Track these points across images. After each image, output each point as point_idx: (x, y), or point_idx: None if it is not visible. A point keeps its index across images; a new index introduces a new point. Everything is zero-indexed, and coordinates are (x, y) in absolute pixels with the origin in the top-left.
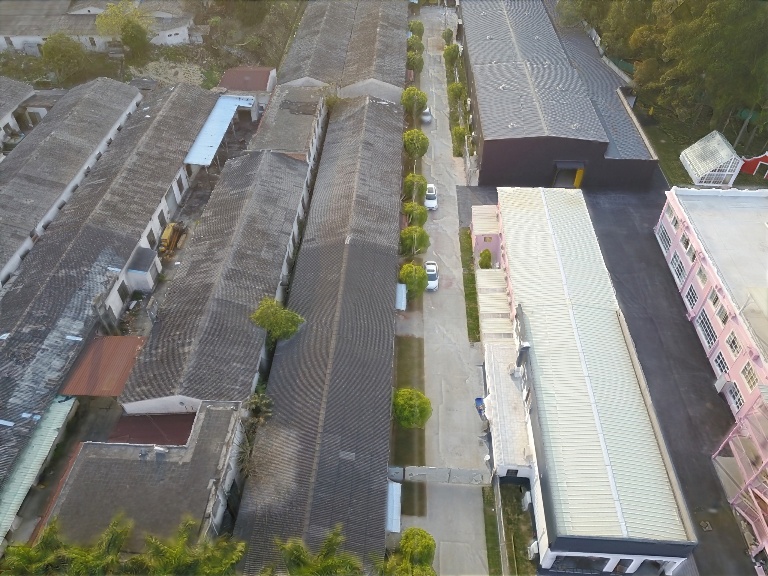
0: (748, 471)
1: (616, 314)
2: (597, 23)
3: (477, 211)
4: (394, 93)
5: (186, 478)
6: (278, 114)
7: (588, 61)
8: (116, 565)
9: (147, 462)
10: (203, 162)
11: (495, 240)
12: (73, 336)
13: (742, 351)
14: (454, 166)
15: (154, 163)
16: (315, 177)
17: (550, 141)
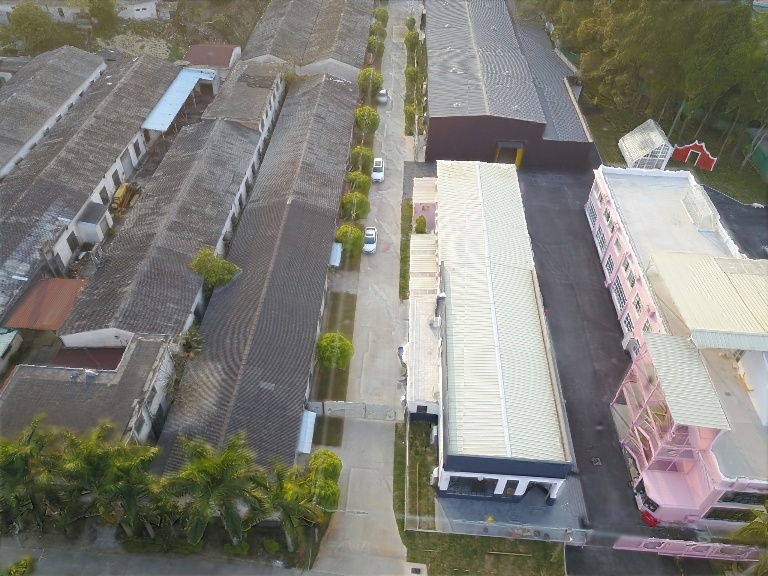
0: (635, 412)
1: (531, 273)
2: (552, 17)
3: (418, 182)
4: (352, 74)
5: (112, 397)
6: (236, 86)
7: (540, 52)
8: (36, 459)
9: (77, 383)
10: (160, 128)
11: (433, 209)
12: (19, 276)
13: (643, 310)
14: (404, 143)
15: (111, 126)
16: (267, 146)
17: (491, 120)
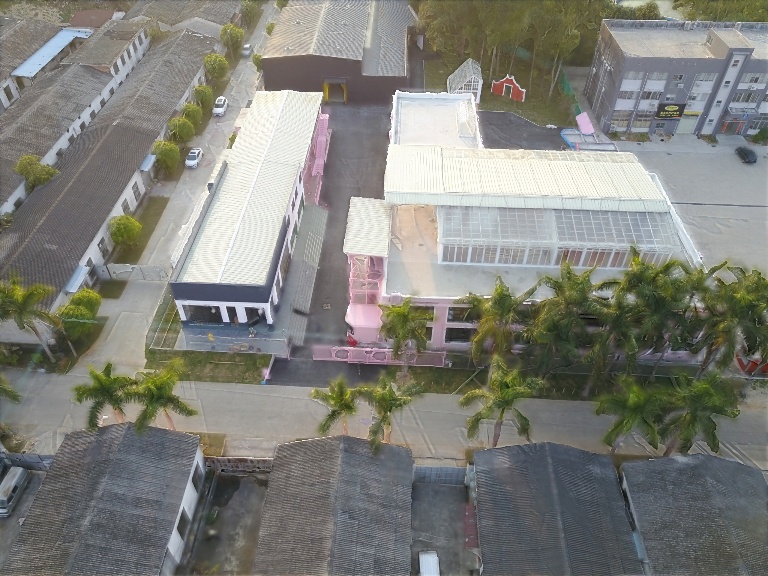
0: None
1: None
2: None
3: (244, 112)
4: (218, 31)
5: None
6: (99, 39)
7: (395, 8)
8: None
9: None
10: (28, 74)
11: None
12: None
13: None
14: (254, 87)
15: None
16: None
17: (313, 59)
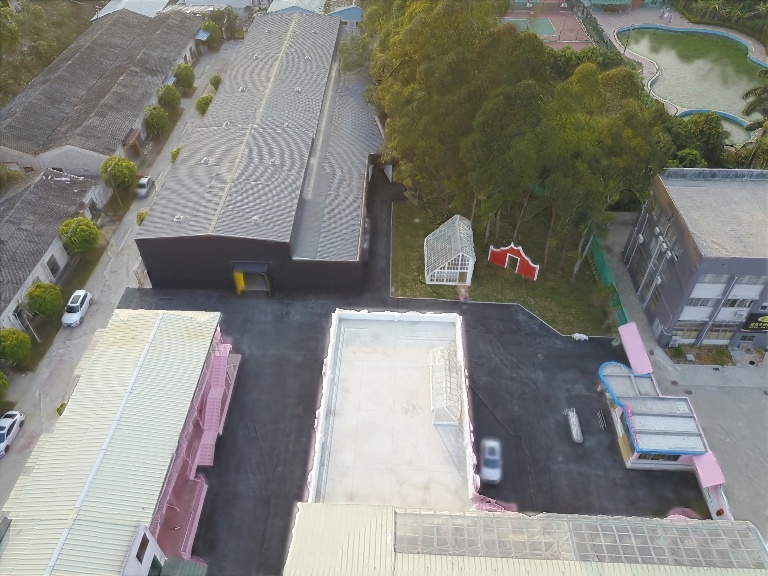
0: None
1: None
2: None
3: (98, 337)
4: (101, 161)
5: None
6: None
7: (355, 117)
8: None
9: None
10: None
11: None
12: None
13: None
14: None
15: None
16: None
17: (215, 240)
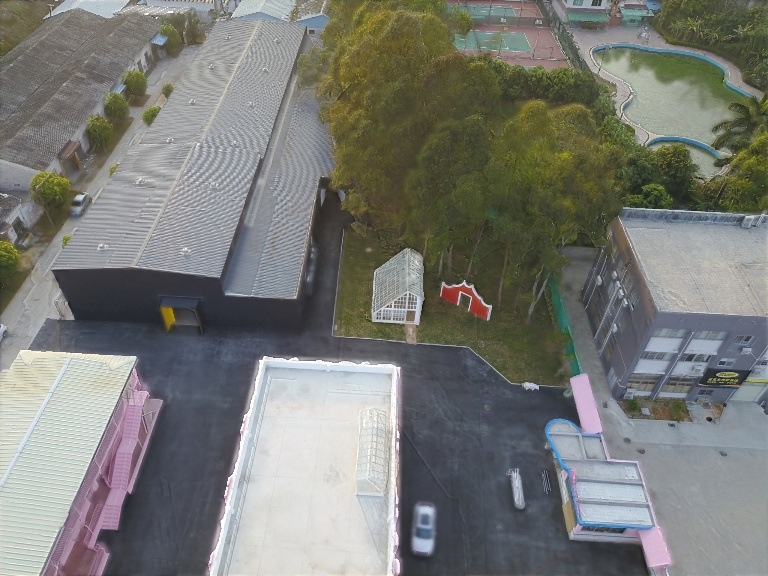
0: None
1: None
2: None
3: None
4: (33, 176)
5: None
6: None
7: (310, 136)
8: None
9: None
10: None
11: None
12: None
13: None
14: None
15: None
16: None
17: (139, 274)
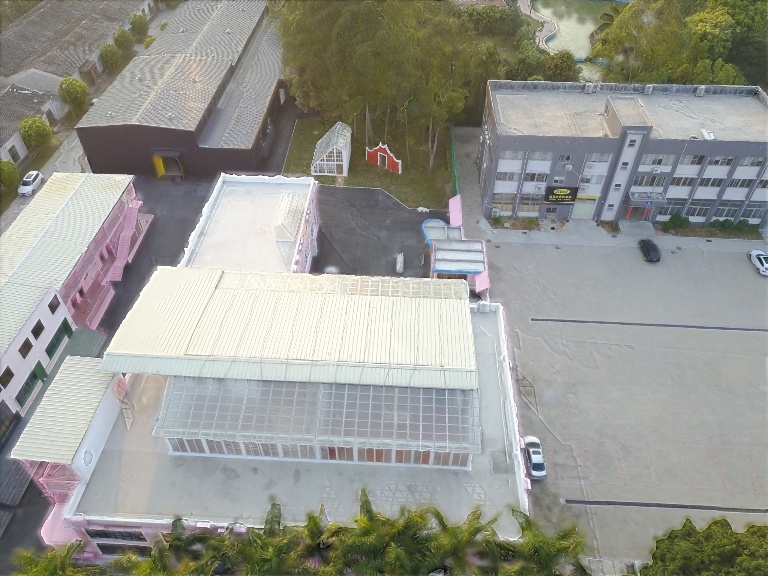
0: None
1: None
2: None
3: None
4: None
5: None
6: None
7: (275, 54)
8: None
9: None
10: None
11: None
12: None
13: None
14: None
15: None
16: None
17: (137, 129)
